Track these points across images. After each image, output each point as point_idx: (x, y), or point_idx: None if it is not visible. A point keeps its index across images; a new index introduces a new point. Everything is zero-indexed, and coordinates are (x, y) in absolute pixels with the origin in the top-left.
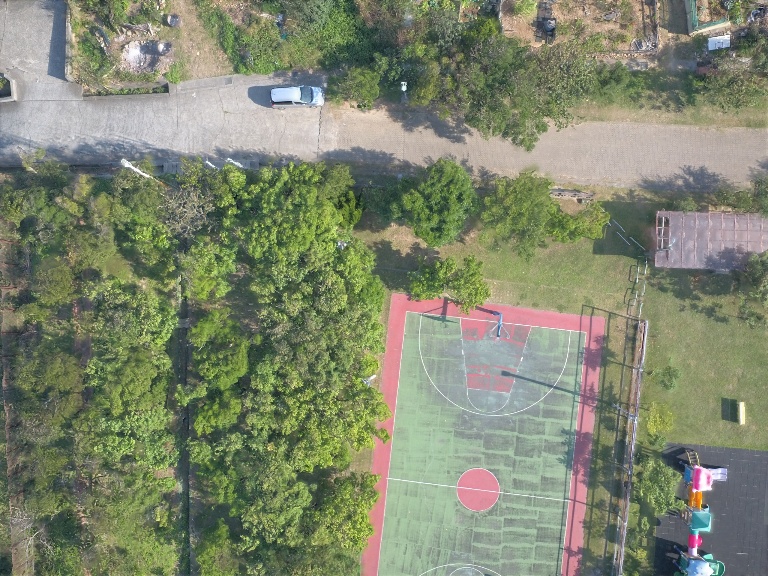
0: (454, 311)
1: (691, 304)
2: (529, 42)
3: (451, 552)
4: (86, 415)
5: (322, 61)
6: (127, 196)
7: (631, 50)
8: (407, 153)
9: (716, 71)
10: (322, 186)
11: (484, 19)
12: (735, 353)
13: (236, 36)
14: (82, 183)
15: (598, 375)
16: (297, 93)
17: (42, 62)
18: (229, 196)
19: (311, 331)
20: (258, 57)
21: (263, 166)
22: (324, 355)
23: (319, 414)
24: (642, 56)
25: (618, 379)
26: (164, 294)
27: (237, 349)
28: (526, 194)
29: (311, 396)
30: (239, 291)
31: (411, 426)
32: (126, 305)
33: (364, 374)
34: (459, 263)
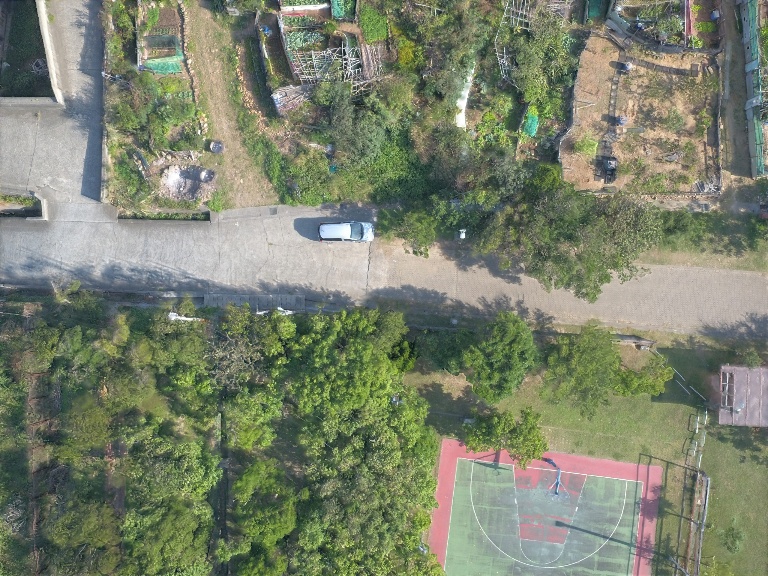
0: (507, 458)
1: (751, 455)
2: (588, 181)
3: None
4: (124, 570)
5: (372, 195)
6: (170, 342)
7: (692, 192)
8: (460, 293)
9: None
10: (376, 338)
11: (547, 167)
12: None
13: (282, 166)
14: (122, 325)
15: (655, 527)
16: (347, 230)
17: (75, 181)
18: (278, 345)
19: (364, 490)
20: (306, 190)
21: (309, 301)
22: (378, 516)
23: (370, 574)
24: (703, 198)
25: (676, 531)
26: (204, 433)
27: (285, 504)
28: (590, 353)
29: (362, 555)
30: (283, 432)
31: None
32: (168, 455)
33: (417, 532)
34: (513, 408)
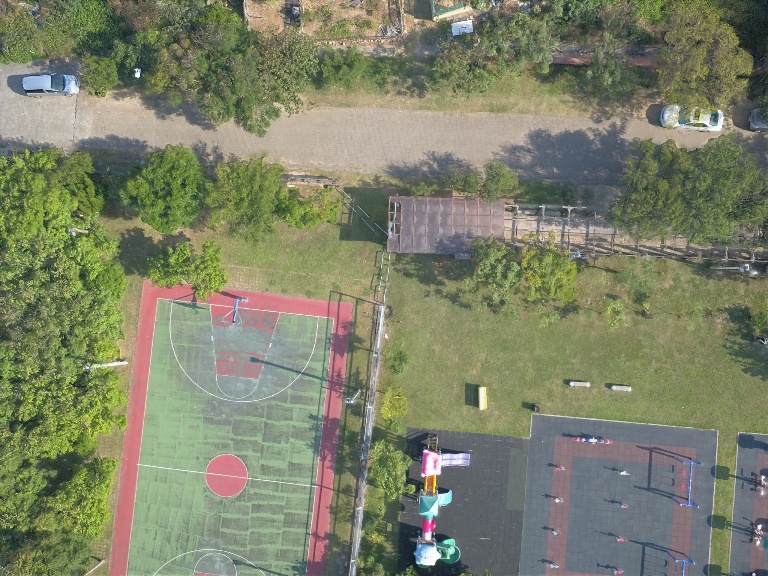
0: None
1: (436, 290)
2: (278, 29)
3: (200, 538)
4: None
5: (77, 49)
6: None
7: (377, 36)
8: (159, 140)
9: (444, 56)
10: (55, 173)
11: (213, 5)
12: (478, 338)
13: None
14: None
15: (345, 361)
16: (48, 81)
17: None
18: None
19: (43, 317)
20: (13, 46)
21: None
22: (53, 341)
23: (55, 400)
24: (389, 42)
25: (365, 365)
26: None
27: None
28: (250, 179)
29: (46, 382)
30: None
31: (161, 412)
32: None
33: (100, 360)
34: None
